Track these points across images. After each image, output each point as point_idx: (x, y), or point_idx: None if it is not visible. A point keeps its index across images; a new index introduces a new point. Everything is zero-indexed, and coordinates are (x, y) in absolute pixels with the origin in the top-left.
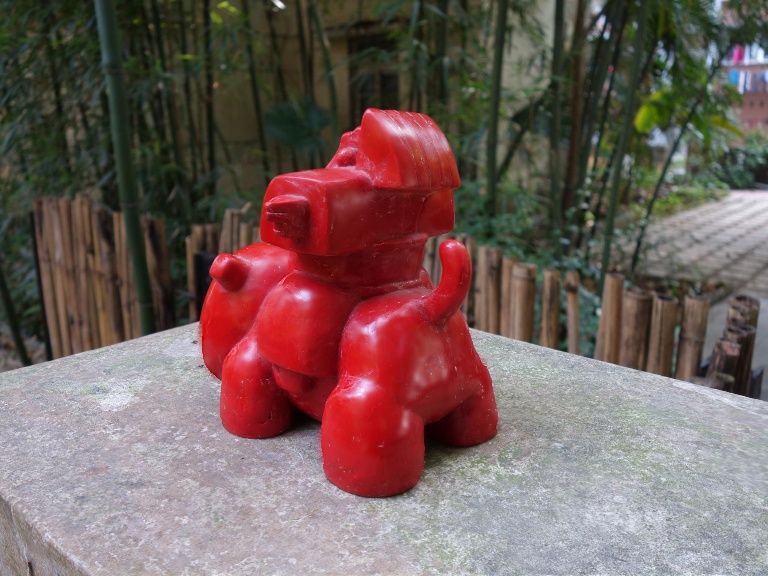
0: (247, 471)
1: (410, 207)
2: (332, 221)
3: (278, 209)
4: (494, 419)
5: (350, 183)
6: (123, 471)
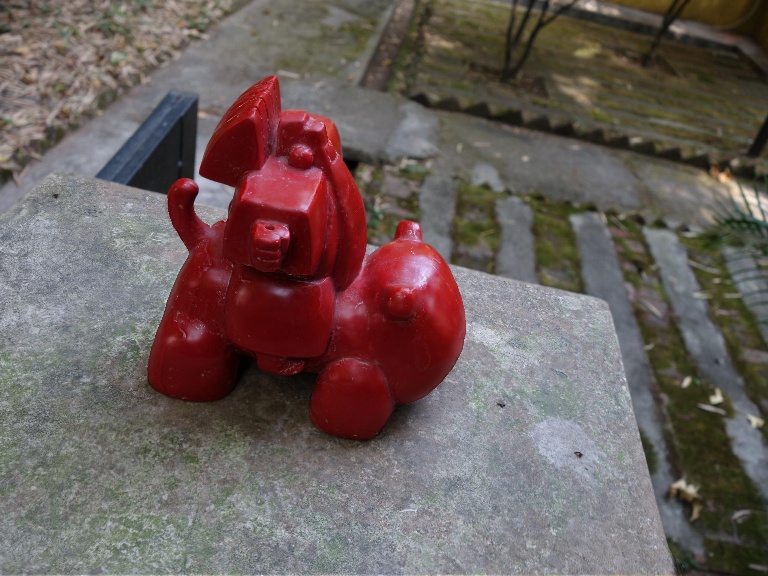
0: None
1: None
2: None
3: None
4: None
5: None
6: None
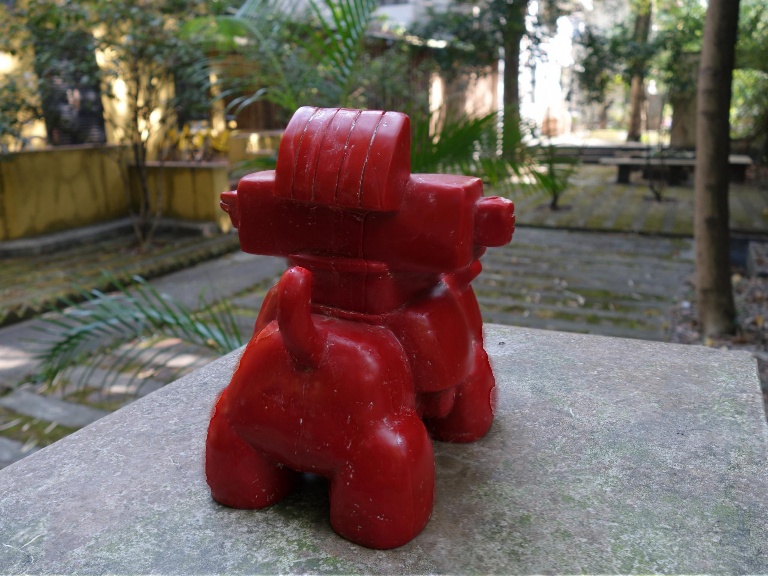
0: None
1: (342, 224)
2: (240, 219)
3: (225, 199)
4: (370, 525)
5: (263, 184)
6: None
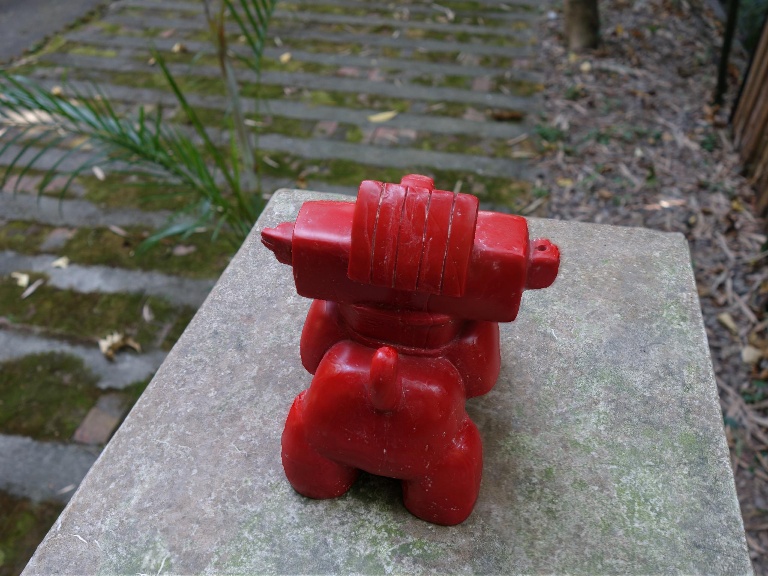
0: (285, 390)
1: None
2: (297, 272)
3: (267, 238)
4: (445, 514)
5: (323, 246)
6: (253, 331)
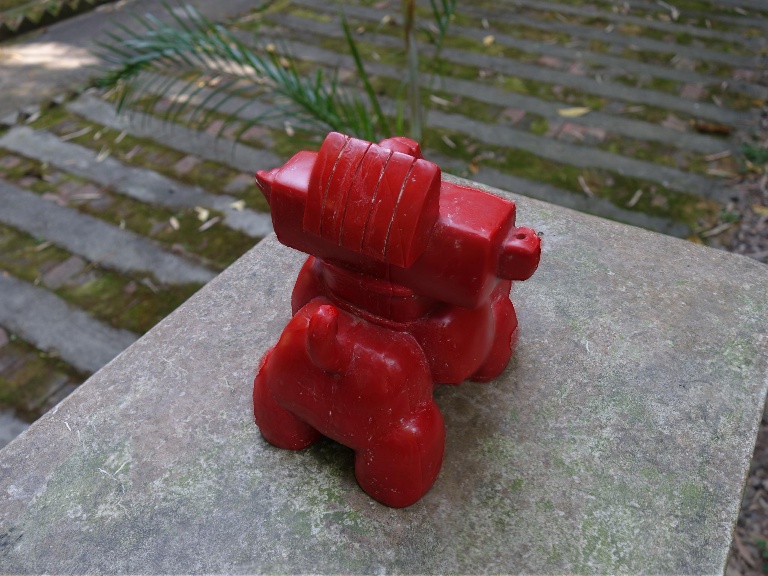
0: None
1: None
2: (274, 217)
3: (260, 181)
4: (385, 493)
5: (295, 194)
6: (288, 280)
